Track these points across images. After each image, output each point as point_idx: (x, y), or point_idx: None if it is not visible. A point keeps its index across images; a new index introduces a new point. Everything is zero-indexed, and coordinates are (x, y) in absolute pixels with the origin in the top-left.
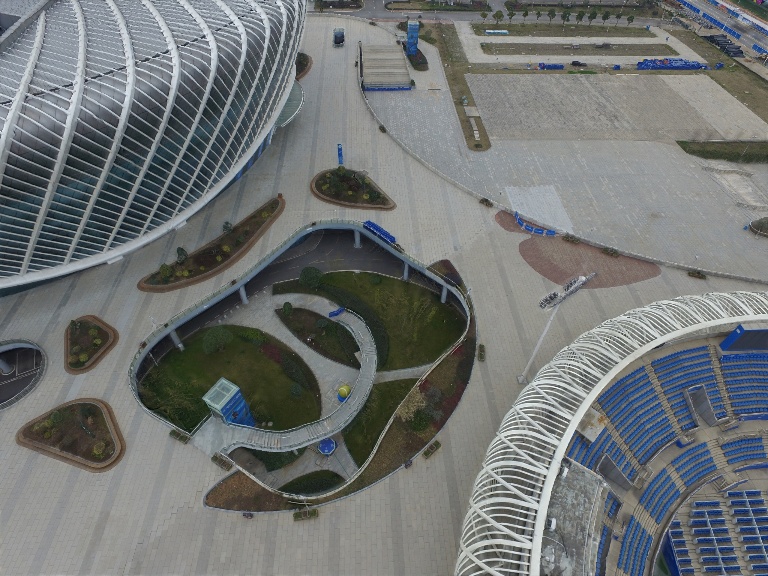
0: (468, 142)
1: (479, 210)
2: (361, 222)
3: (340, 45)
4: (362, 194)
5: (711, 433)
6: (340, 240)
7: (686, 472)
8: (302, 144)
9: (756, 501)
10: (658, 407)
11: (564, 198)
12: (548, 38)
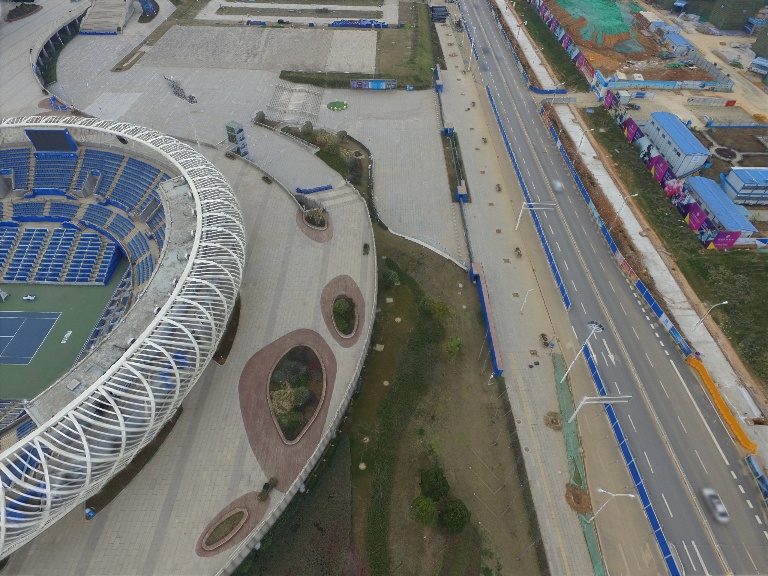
0: (115, 67)
1: (35, 96)
2: None
3: (74, 0)
4: None
5: (13, 199)
6: None
7: None
8: None
9: (12, 233)
10: None
11: (140, 100)
12: (285, 5)
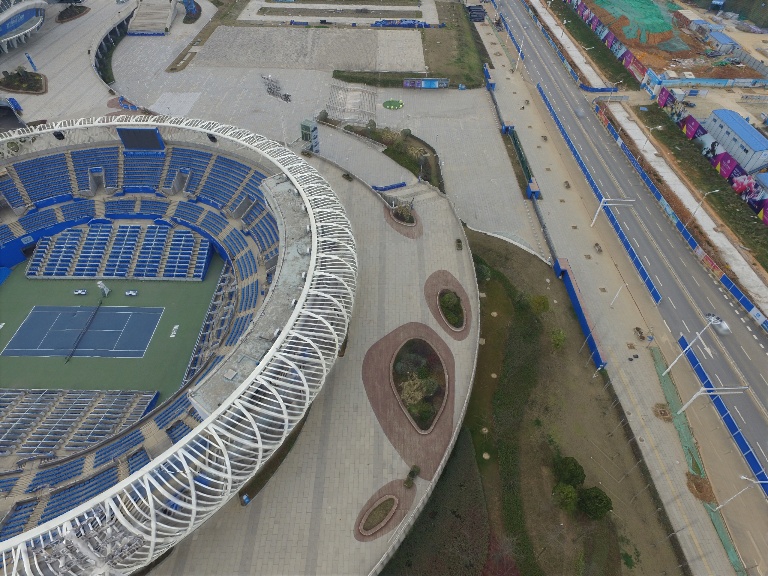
0: (169, 67)
1: (103, 96)
2: (5, 98)
3: (121, 2)
4: None
5: None
6: (12, 118)
7: (69, 213)
8: (21, 59)
9: (106, 230)
10: (66, 177)
11: (200, 100)
12: (324, 5)
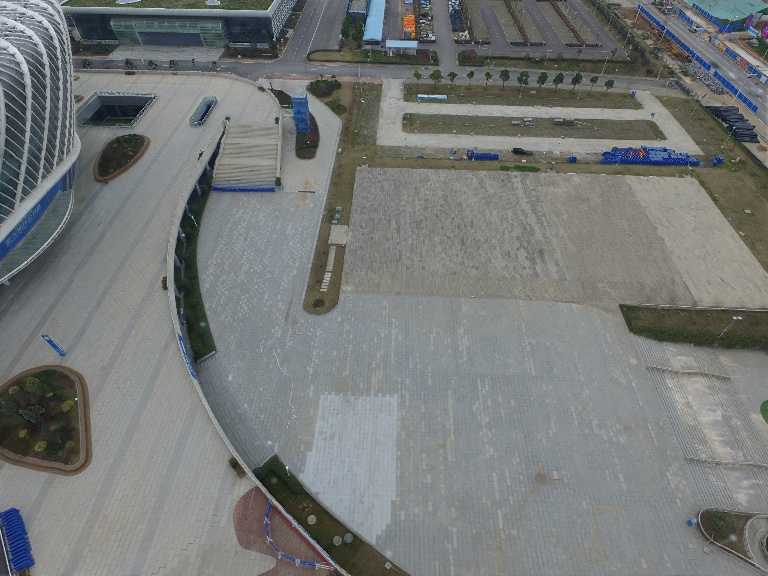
0: (307, 294)
1: (218, 483)
2: None
3: (197, 124)
4: (45, 435)
5: None
6: None
7: None
8: (33, 308)
9: None
10: None
11: (404, 426)
12: (496, 107)
